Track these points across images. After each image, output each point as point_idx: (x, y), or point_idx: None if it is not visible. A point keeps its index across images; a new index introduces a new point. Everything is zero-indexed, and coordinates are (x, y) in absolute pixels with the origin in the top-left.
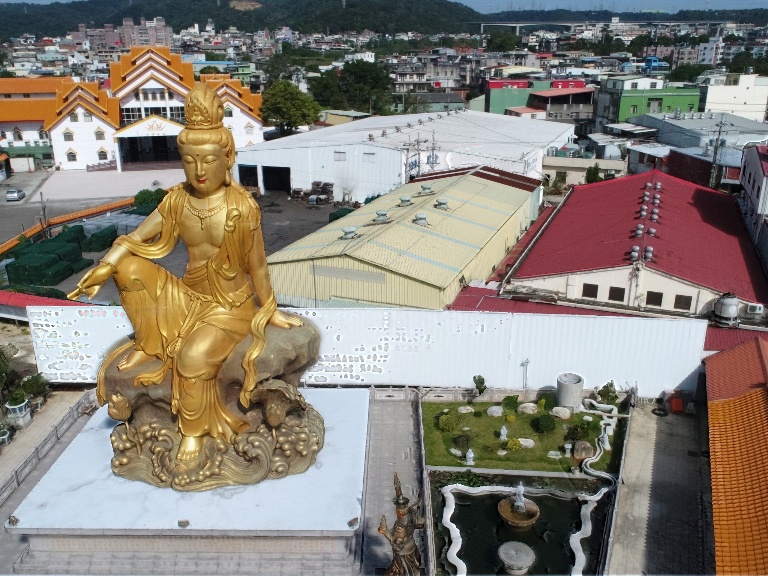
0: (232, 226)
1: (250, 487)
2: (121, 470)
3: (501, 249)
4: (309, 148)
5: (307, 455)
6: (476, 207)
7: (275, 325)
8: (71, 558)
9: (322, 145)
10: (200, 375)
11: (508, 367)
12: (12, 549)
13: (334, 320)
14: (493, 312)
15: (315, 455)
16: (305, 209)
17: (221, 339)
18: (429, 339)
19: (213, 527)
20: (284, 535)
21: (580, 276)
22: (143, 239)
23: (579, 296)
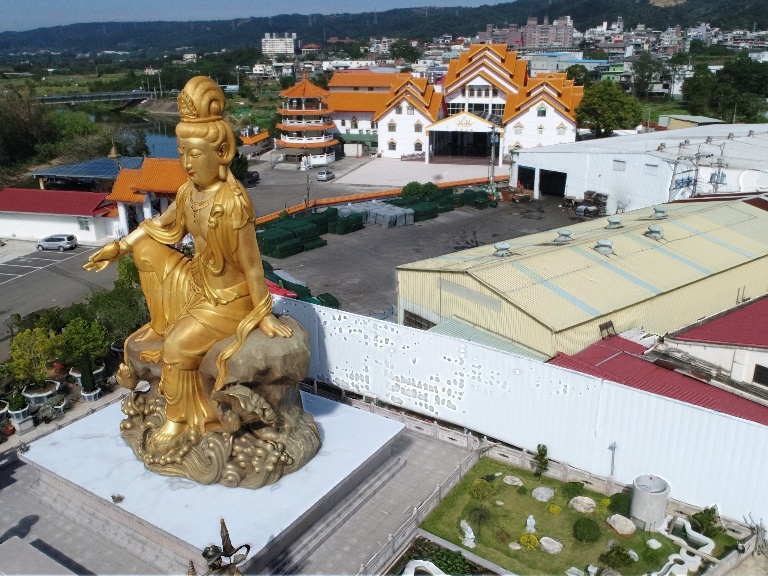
0: (213, 222)
1: (200, 486)
2: (125, 433)
3: (726, 299)
4: (588, 154)
5: (260, 472)
6: (708, 241)
7: (262, 330)
8: (58, 496)
9: (602, 152)
10: (174, 363)
11: (594, 445)
12: None
13: (410, 340)
14: (578, 372)
15: (277, 475)
16: (567, 219)
17: (199, 333)
18: (506, 386)
19: (135, 512)
20: (182, 544)
21: (752, 353)
22: (163, 224)
23: (748, 380)
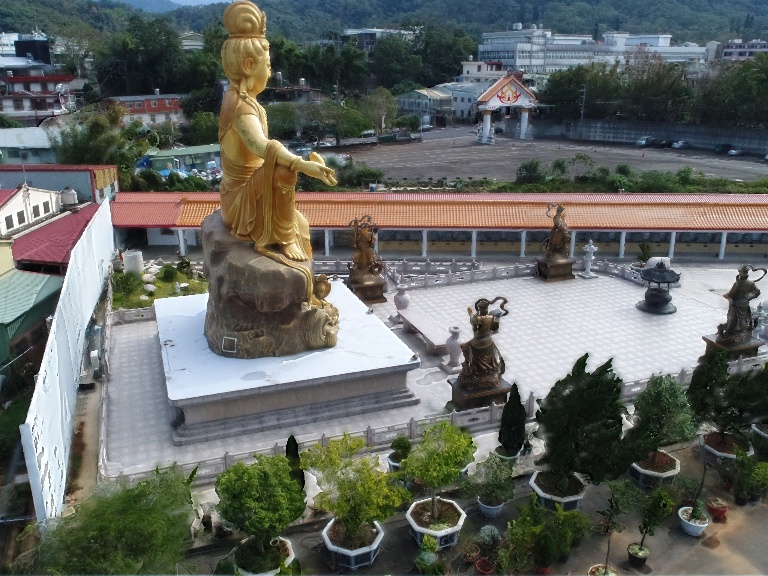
0: None
1: None
2: None
3: None
4: None
5: None
6: None
7: None
8: None
9: None
10: None
11: None
12: (401, 415)
13: None
14: (88, 228)
15: None
16: None
17: None
18: None
19: None
20: None
21: (2, 212)
22: None
23: None
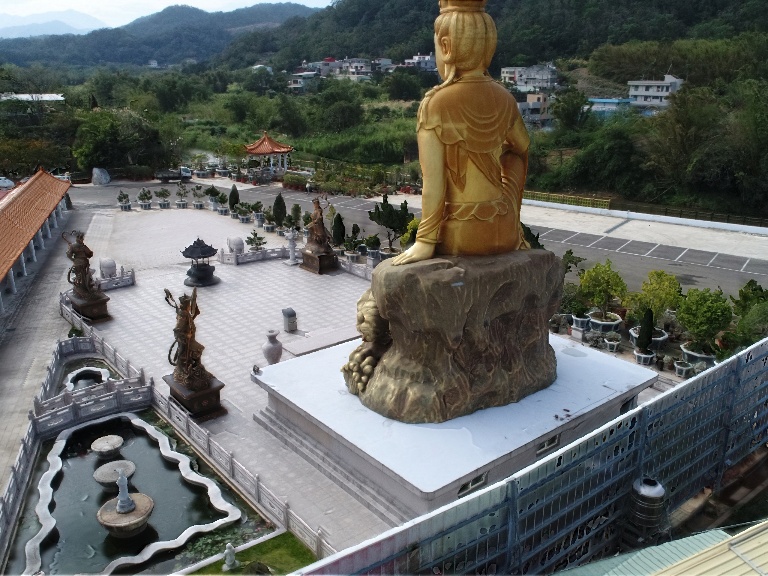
0: None
1: None
2: None
3: None
4: None
5: None
6: None
7: None
8: None
9: None
10: None
11: None
12: None
13: None
14: None
15: None
16: None
17: None
18: None
19: None
20: None
21: None
22: None
23: None
